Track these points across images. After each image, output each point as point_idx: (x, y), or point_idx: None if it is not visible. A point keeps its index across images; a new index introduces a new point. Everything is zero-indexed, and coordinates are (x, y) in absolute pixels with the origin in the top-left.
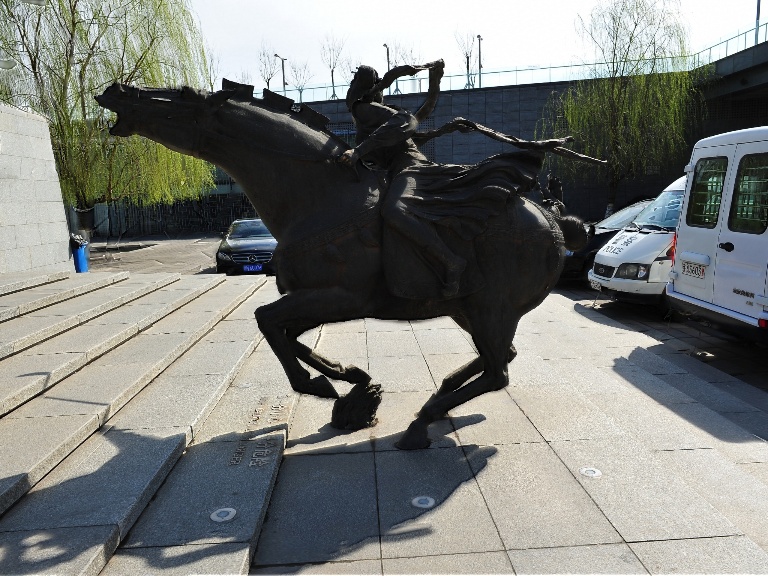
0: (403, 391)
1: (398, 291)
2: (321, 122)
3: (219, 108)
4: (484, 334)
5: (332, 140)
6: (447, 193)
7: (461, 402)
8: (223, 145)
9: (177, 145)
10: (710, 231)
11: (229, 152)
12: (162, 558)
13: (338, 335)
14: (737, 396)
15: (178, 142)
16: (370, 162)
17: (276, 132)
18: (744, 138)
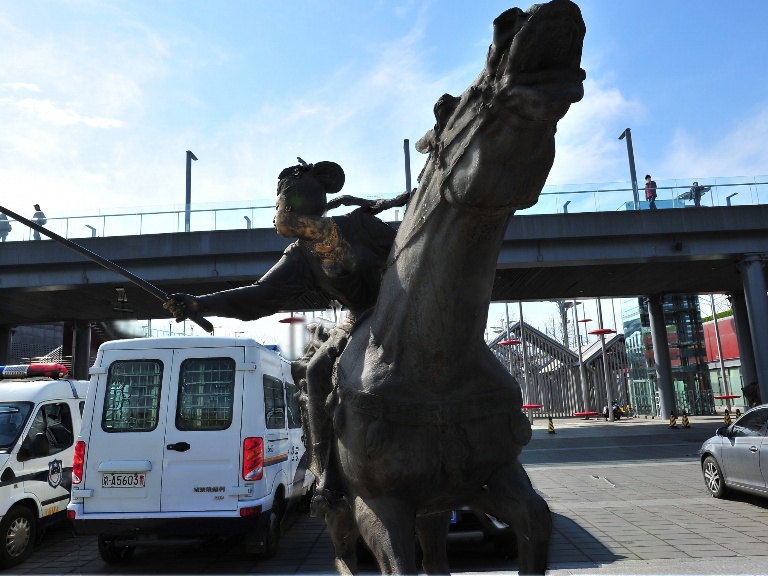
0: None
1: None
2: None
3: None
4: None
5: None
6: None
7: None
8: None
9: None
10: (147, 434)
11: None
12: None
13: None
14: None
15: None
16: (340, 291)
17: None
18: (182, 344)
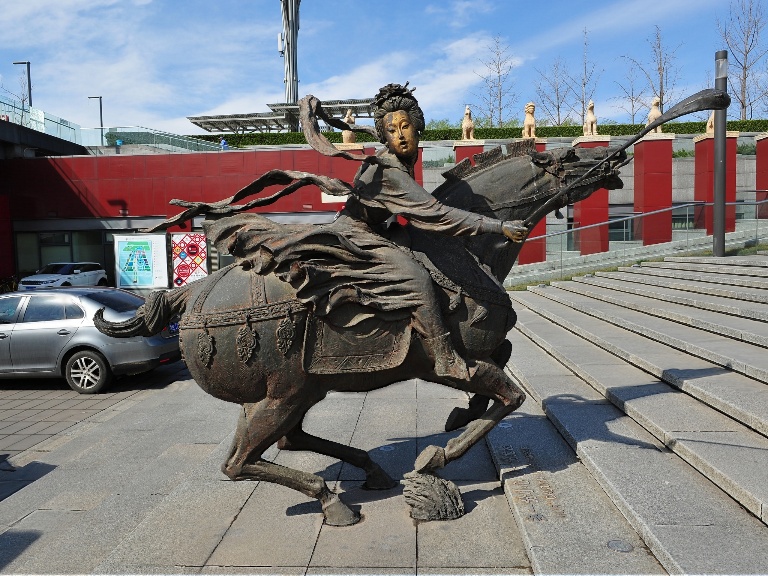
0: (363, 567)
1: None
2: None
3: None
4: None
5: None
6: None
7: None
8: None
9: None
10: None
11: None
12: (520, 414)
13: None
14: None
15: None
16: None
17: None
18: None
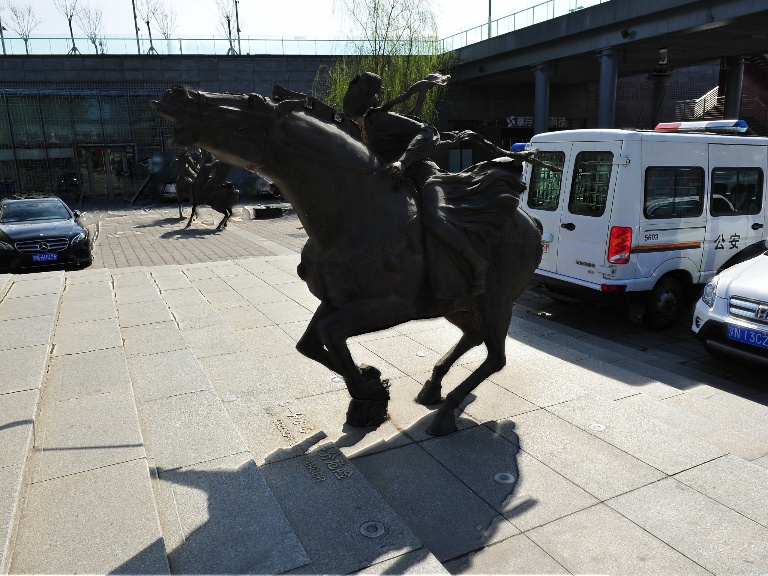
0: None
1: (440, 293)
2: (358, 132)
3: (285, 119)
4: (494, 324)
5: (369, 150)
6: (466, 200)
7: (476, 385)
8: (288, 158)
9: (246, 158)
10: (551, 213)
11: (293, 165)
12: None
13: (251, 331)
14: None
15: (247, 155)
16: None
17: (333, 144)
18: (579, 138)
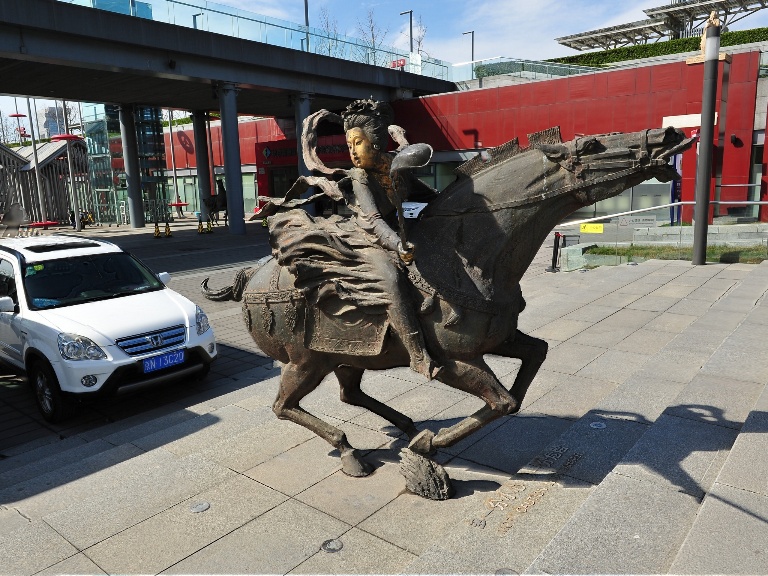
0: (321, 512)
1: None
2: None
3: None
4: None
5: None
6: None
7: None
8: None
9: None
10: None
11: None
12: (636, 417)
13: None
14: (50, 455)
15: None
16: None
17: None
18: None
